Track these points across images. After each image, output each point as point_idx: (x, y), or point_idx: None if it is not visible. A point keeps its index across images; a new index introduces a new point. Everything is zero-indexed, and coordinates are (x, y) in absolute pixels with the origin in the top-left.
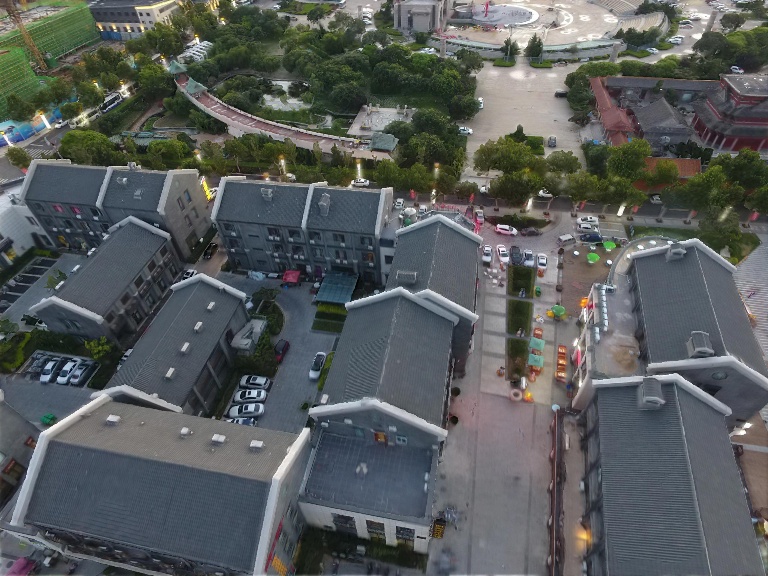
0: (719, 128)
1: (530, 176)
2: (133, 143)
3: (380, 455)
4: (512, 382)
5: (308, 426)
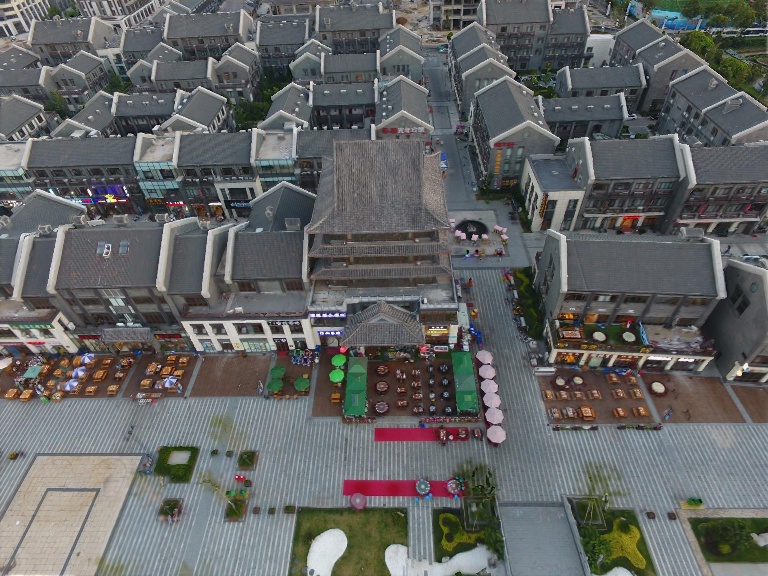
0: None
1: None
2: (720, 54)
3: (567, 177)
4: None
5: None
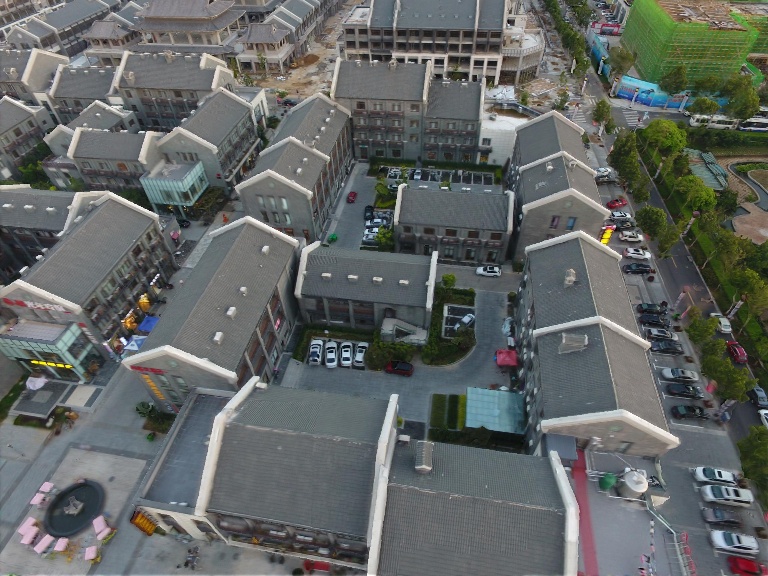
0: None
1: None
2: (684, 165)
3: None
4: None
5: None
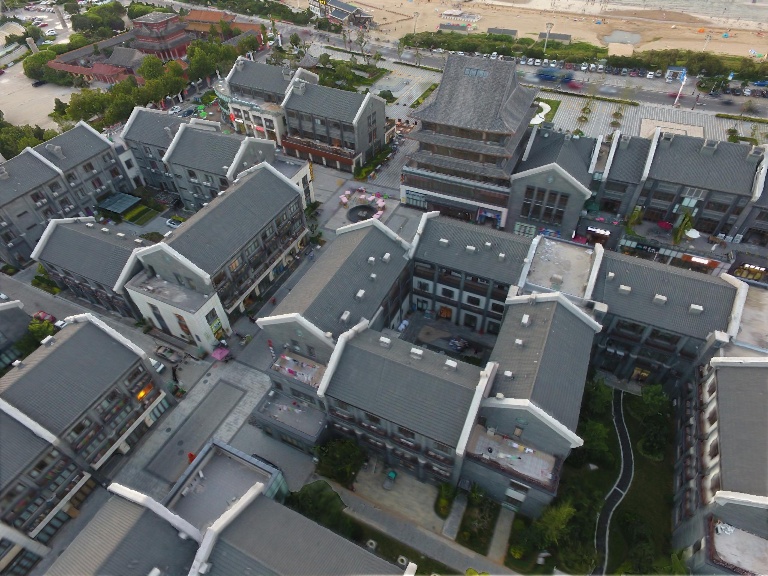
0: (163, 47)
1: (127, 96)
2: None
3: None
4: None
5: None
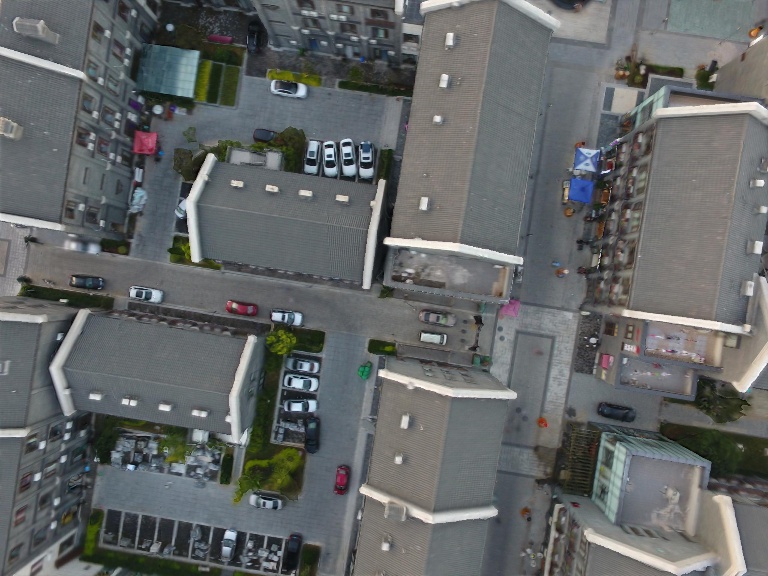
0: None
1: None
2: None
3: None
4: None
5: (365, 87)
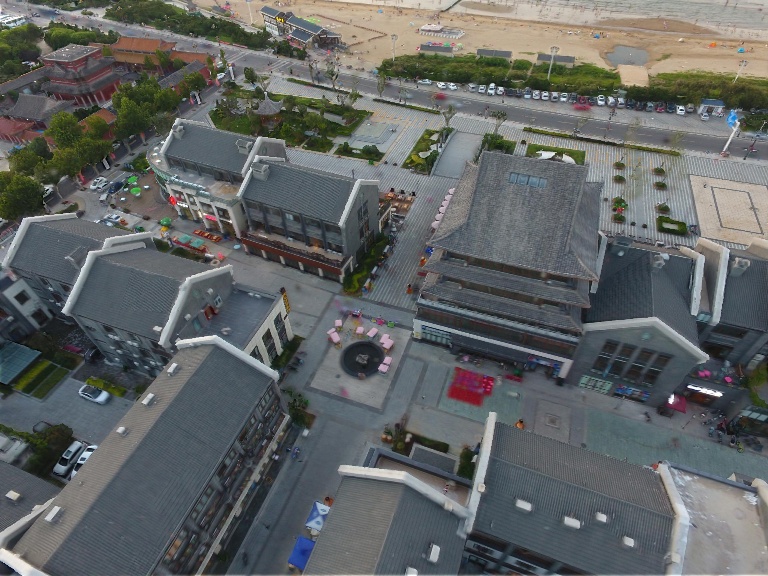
0: (84, 90)
1: (25, 178)
2: None
3: (221, 319)
4: (204, 262)
5: None
